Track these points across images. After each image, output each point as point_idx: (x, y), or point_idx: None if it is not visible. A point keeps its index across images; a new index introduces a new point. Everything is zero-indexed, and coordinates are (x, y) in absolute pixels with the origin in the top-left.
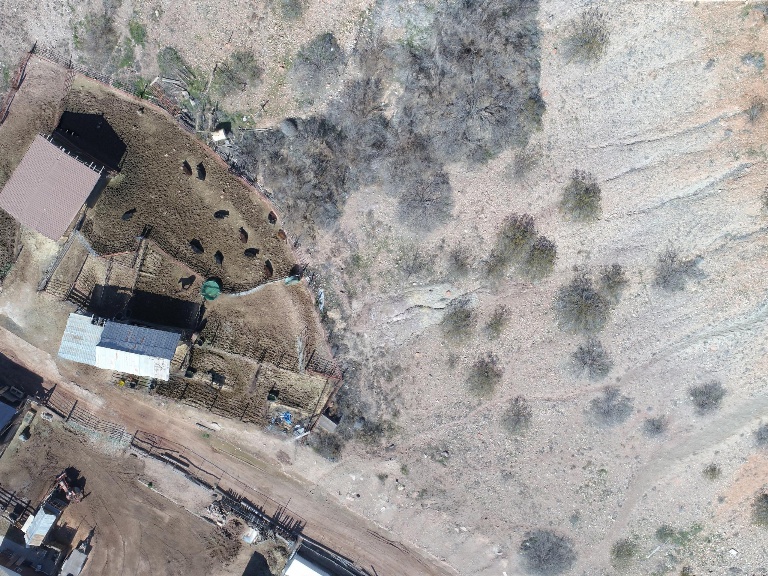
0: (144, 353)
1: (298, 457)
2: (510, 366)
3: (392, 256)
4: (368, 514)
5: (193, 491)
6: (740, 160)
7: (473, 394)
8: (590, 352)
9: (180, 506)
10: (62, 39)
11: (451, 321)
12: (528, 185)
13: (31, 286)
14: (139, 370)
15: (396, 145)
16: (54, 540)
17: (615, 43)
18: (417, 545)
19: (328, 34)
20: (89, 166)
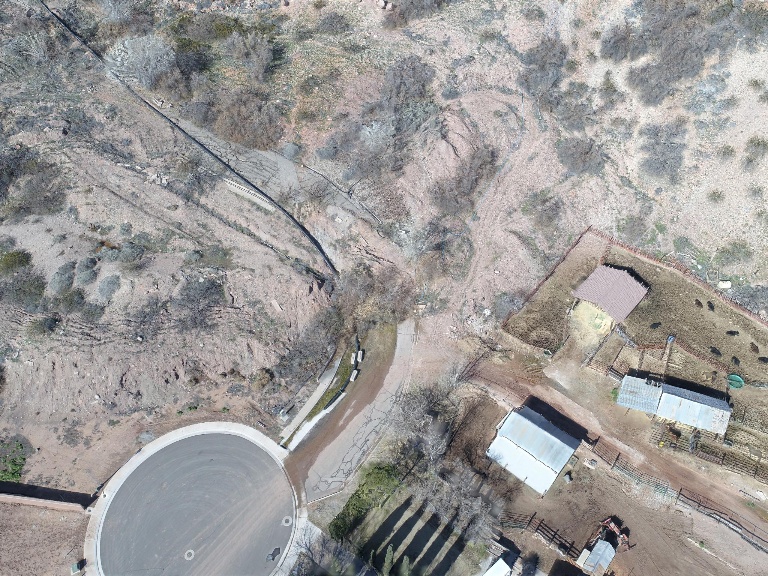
0: (706, 404)
1: None
2: None
3: None
4: None
5: (751, 556)
6: None
7: None
8: None
9: (739, 572)
10: (609, 226)
11: None
12: None
13: (575, 362)
14: (697, 421)
15: None
16: None
17: None
18: None
19: None
20: (640, 284)
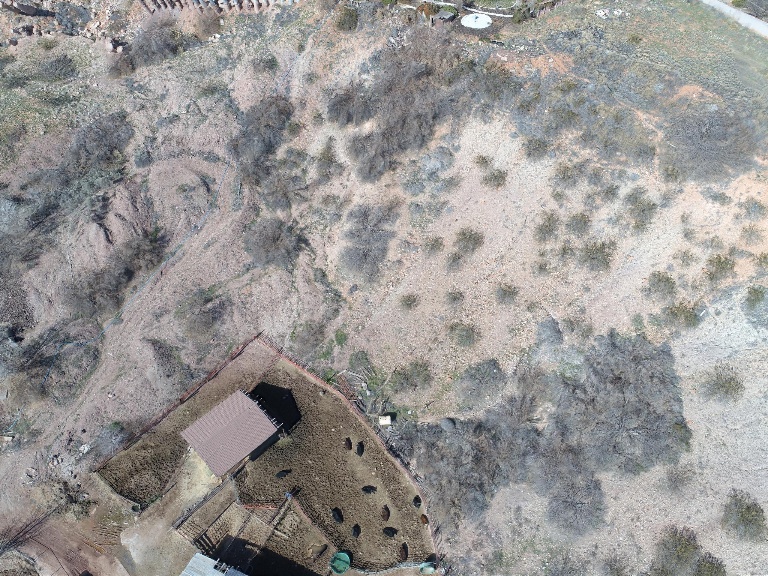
0: None
1: None
2: None
3: (539, 557)
4: None
5: None
6: None
7: None
8: None
9: None
10: (282, 333)
11: None
12: (684, 498)
13: (165, 523)
14: None
15: (550, 448)
16: None
17: (749, 388)
18: None
19: (493, 360)
20: (271, 420)
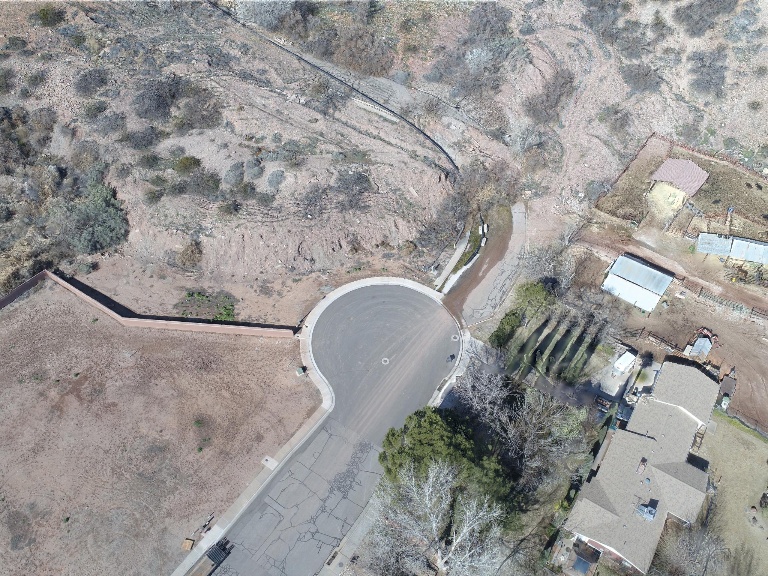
0: None
1: None
2: None
3: None
4: None
5: None
6: None
7: None
8: None
9: None
10: (669, 132)
11: None
12: None
13: (657, 229)
14: (762, 259)
15: None
16: None
17: None
18: None
19: None
20: (703, 170)
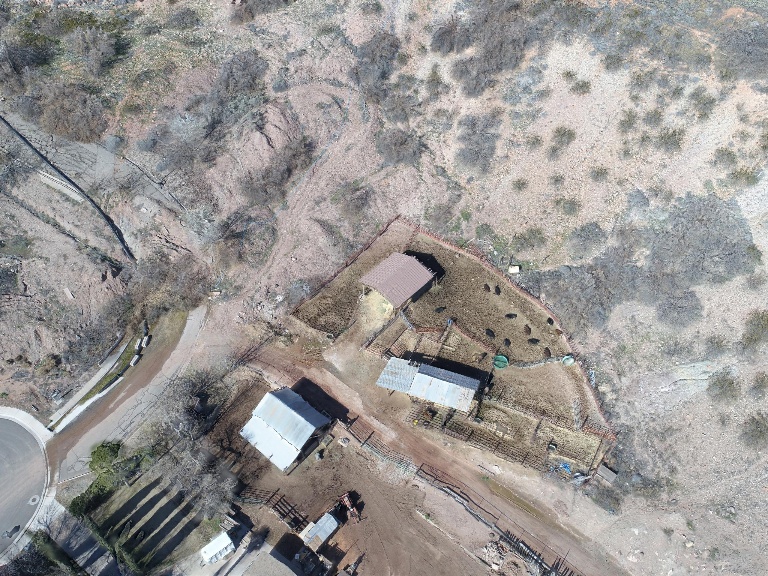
0: (454, 383)
1: (576, 508)
2: None
3: (654, 345)
4: None
5: (471, 527)
6: None
7: (749, 449)
8: None
9: (455, 542)
10: (417, 214)
11: (716, 387)
12: (762, 292)
13: (355, 346)
14: (445, 399)
15: (652, 273)
16: (324, 556)
17: None
18: None
19: (594, 223)
20: (428, 270)
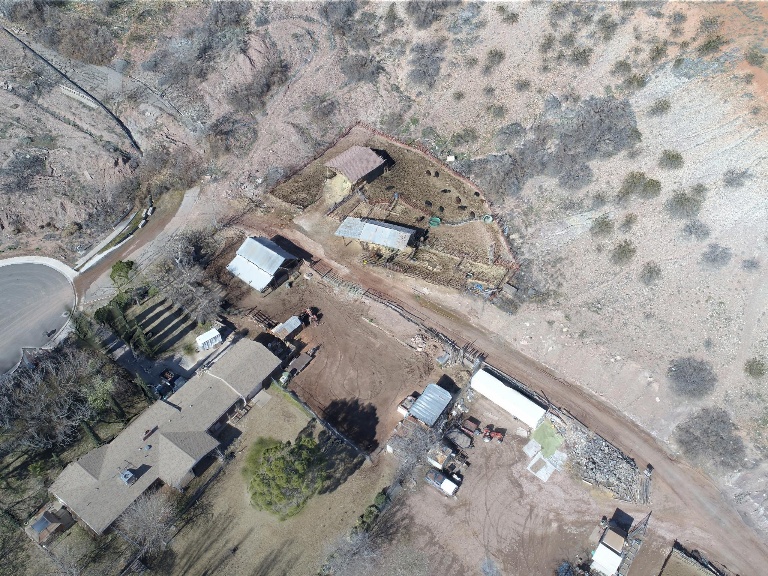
0: (395, 229)
1: (485, 313)
2: (640, 244)
3: (555, 204)
4: (537, 356)
5: (403, 326)
6: (755, 128)
7: (616, 266)
8: (694, 226)
9: (391, 335)
10: (374, 121)
11: (597, 227)
12: (638, 160)
13: (320, 214)
14: (387, 241)
15: None
16: None
17: (675, 106)
18: (579, 382)
19: (517, 122)
20: (379, 157)
